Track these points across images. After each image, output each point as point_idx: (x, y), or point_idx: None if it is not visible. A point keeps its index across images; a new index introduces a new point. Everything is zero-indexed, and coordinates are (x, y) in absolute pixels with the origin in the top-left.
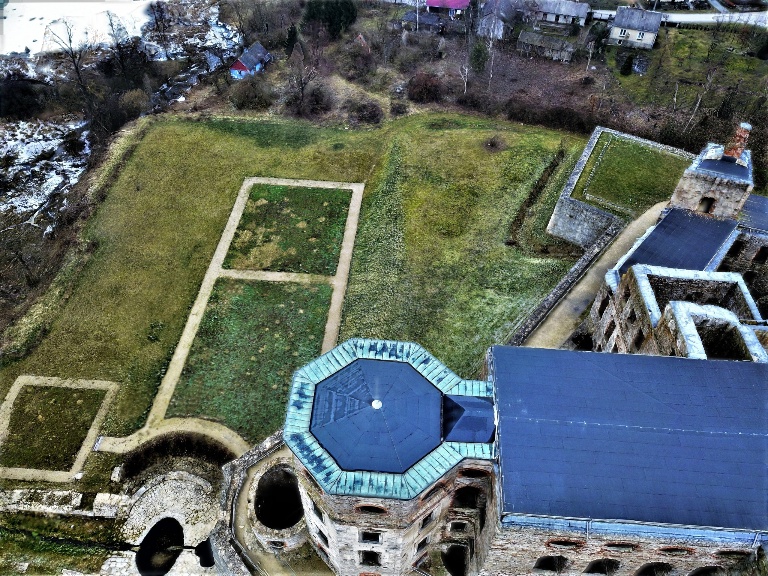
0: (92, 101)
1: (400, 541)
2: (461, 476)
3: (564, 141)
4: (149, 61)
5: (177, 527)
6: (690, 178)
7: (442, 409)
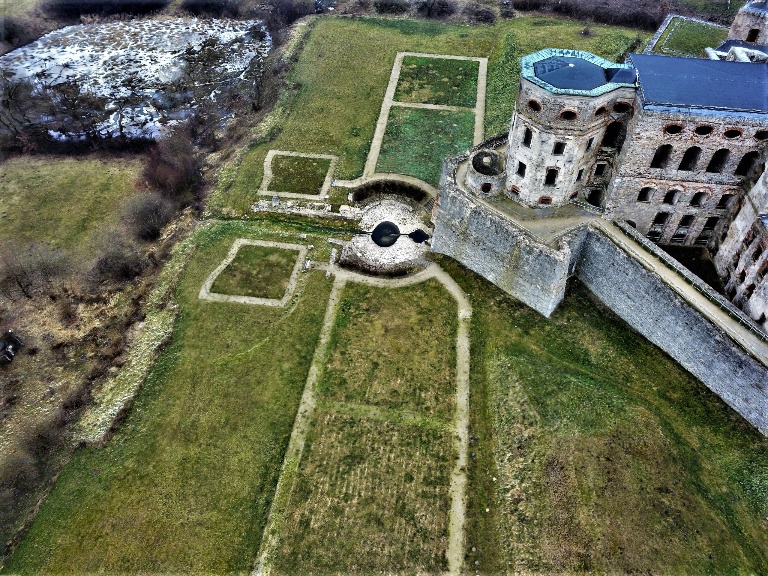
0: (273, 1)
1: (576, 152)
2: (614, 111)
3: (640, 34)
4: None
5: (394, 226)
6: (743, 15)
7: (605, 74)
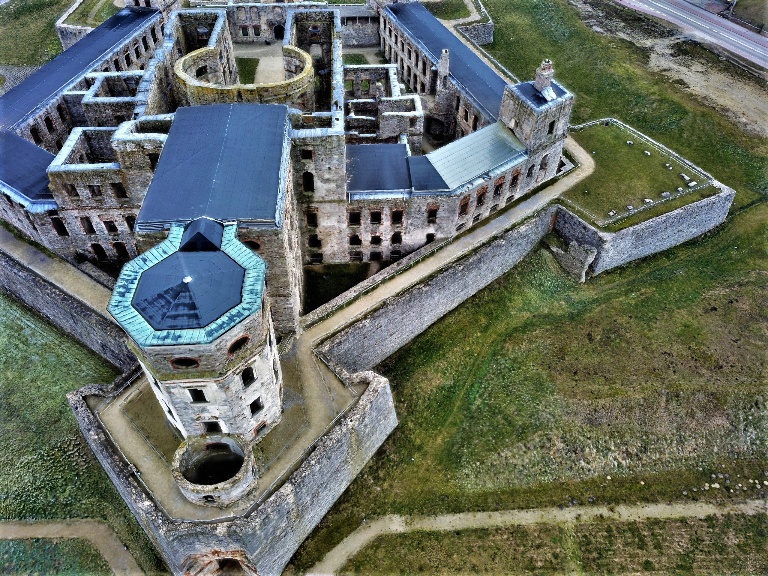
0: None
1: None
2: None
3: None
4: None
5: None
6: None
7: None
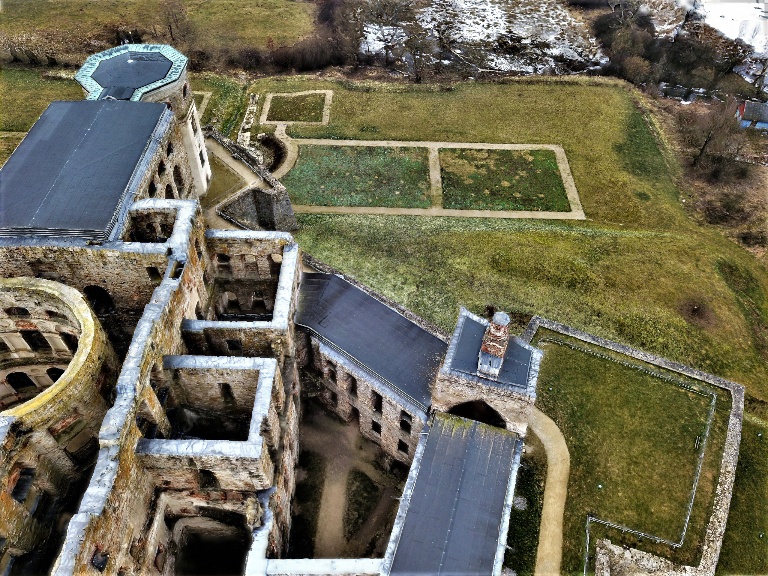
0: None
1: None
2: None
3: None
4: (738, 73)
5: None
6: None
7: None
